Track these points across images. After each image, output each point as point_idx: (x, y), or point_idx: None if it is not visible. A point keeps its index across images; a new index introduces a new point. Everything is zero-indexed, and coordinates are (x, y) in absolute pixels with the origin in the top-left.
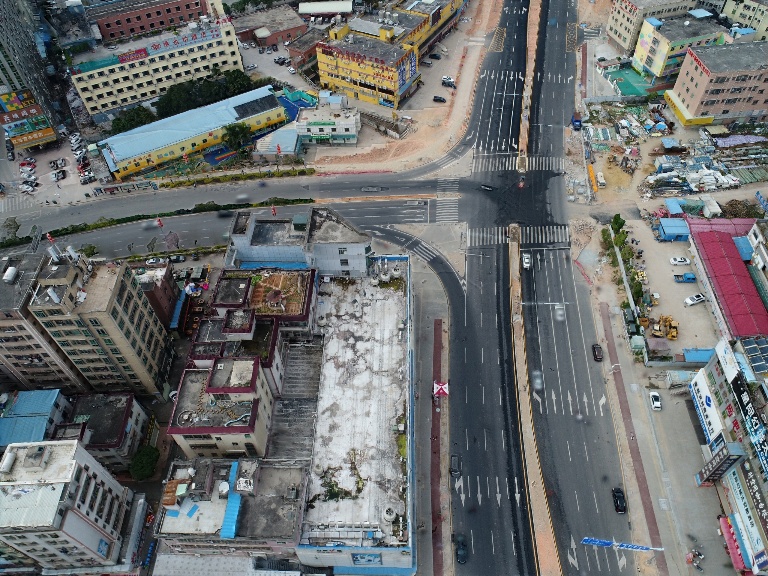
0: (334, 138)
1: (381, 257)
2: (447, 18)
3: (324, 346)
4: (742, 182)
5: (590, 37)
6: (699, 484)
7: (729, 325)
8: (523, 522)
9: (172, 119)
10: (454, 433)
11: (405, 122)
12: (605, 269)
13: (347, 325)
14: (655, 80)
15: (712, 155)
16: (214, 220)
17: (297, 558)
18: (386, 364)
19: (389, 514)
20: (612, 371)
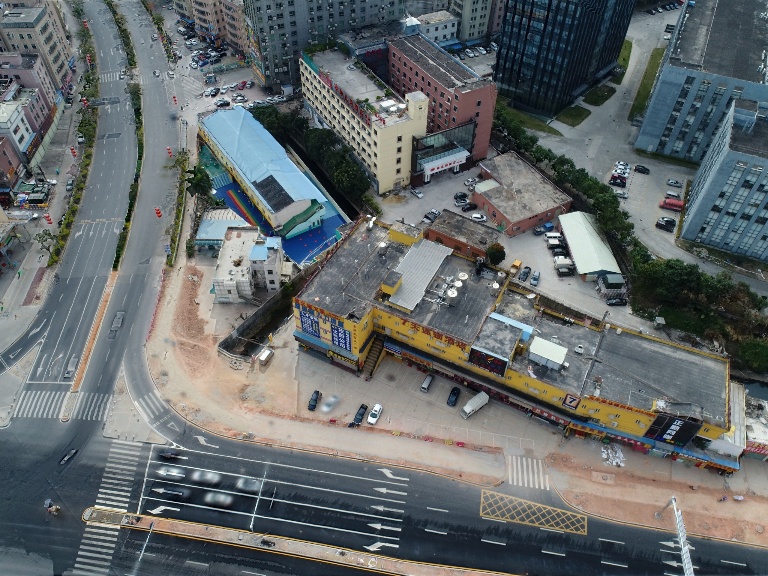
0: None
1: None
2: (541, 398)
3: None
4: None
5: None
6: None
7: None
8: None
9: (266, 139)
10: None
11: None
12: None
13: None
14: None
15: None
16: (118, 201)
17: None
18: None
19: None
20: None
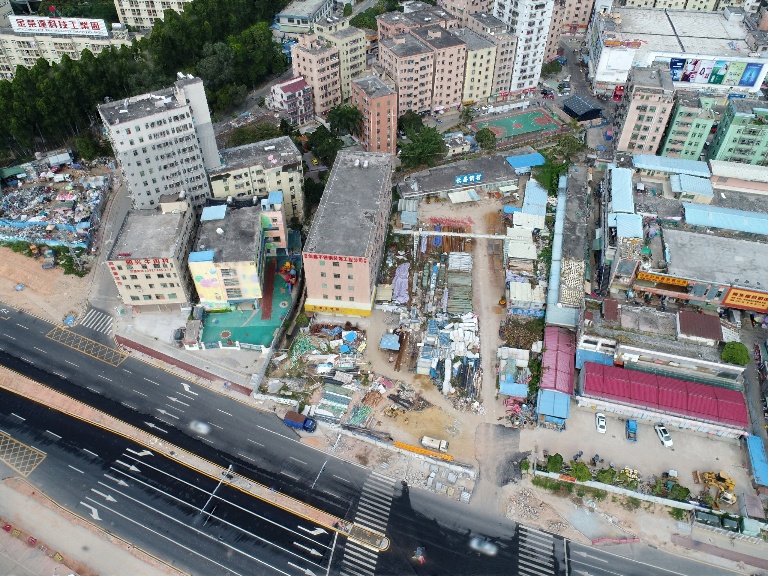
0: None
1: None
2: None
3: None
4: None
5: (105, 325)
6: None
7: None
8: None
9: None
10: None
11: None
12: (608, 510)
13: None
14: (257, 303)
15: None
16: None
17: None
18: None
19: None
20: None
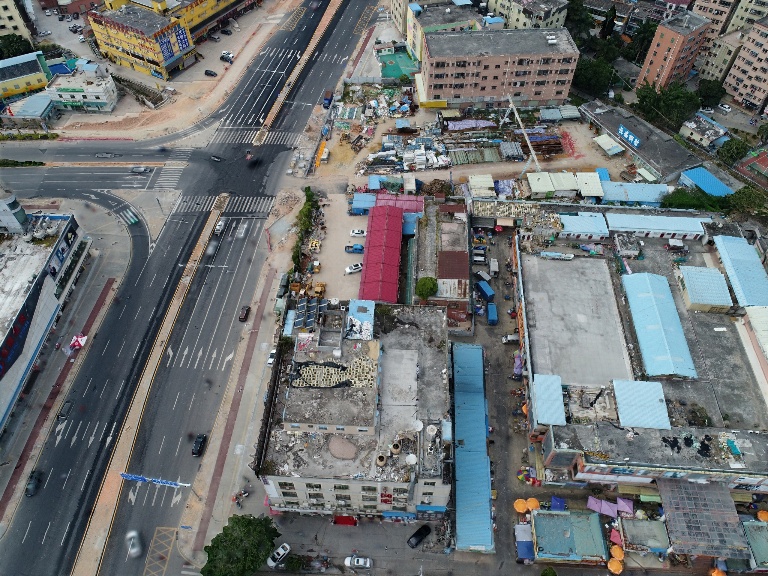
0: (87, 105)
1: (44, 216)
2: None
3: None
4: (454, 163)
5: (382, 21)
6: None
7: (359, 291)
8: (103, 462)
9: None
10: (78, 382)
11: None
12: (290, 238)
13: None
14: (419, 64)
15: (439, 137)
16: None
17: None
18: (2, 313)
19: None
20: (251, 331)
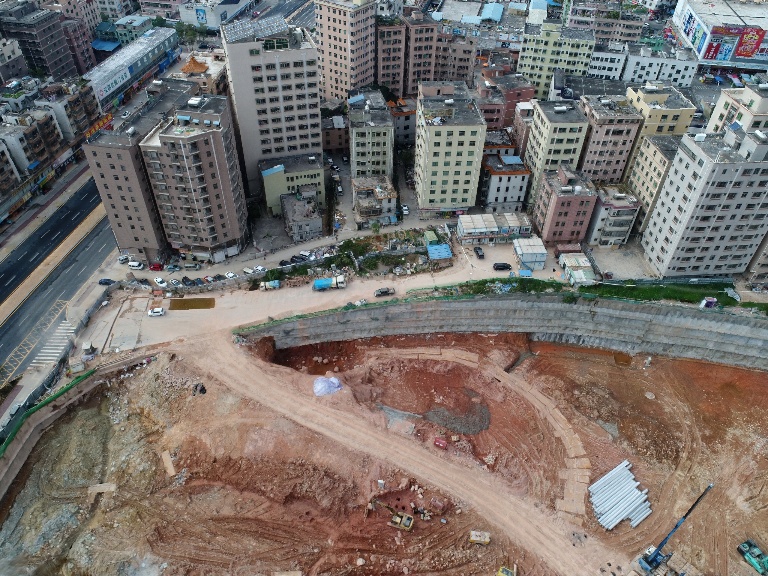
0: None
1: None
2: None
3: None
4: None
5: None
6: None
7: None
8: None
9: None
10: None
11: None
12: None
13: None
14: None
15: None
16: None
17: (180, 16)
18: None
19: (211, 2)
20: None
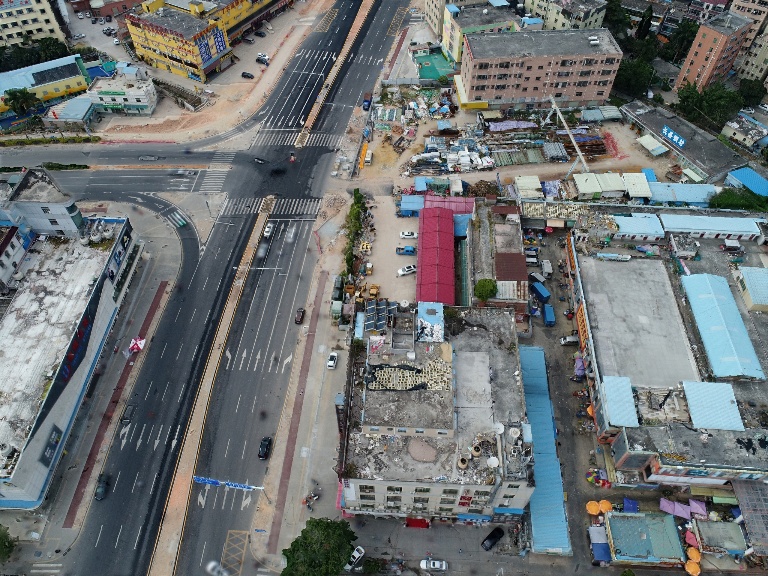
0: (128, 108)
1: (99, 219)
2: None
3: (13, 299)
4: (498, 164)
5: (415, 22)
6: (339, 435)
7: (416, 293)
8: (170, 465)
9: None
10: (139, 385)
11: (207, 96)
12: (340, 240)
13: (43, 280)
14: (456, 65)
15: (481, 138)
16: None
17: None
18: (65, 317)
19: (1, 449)
20: (307, 333)
